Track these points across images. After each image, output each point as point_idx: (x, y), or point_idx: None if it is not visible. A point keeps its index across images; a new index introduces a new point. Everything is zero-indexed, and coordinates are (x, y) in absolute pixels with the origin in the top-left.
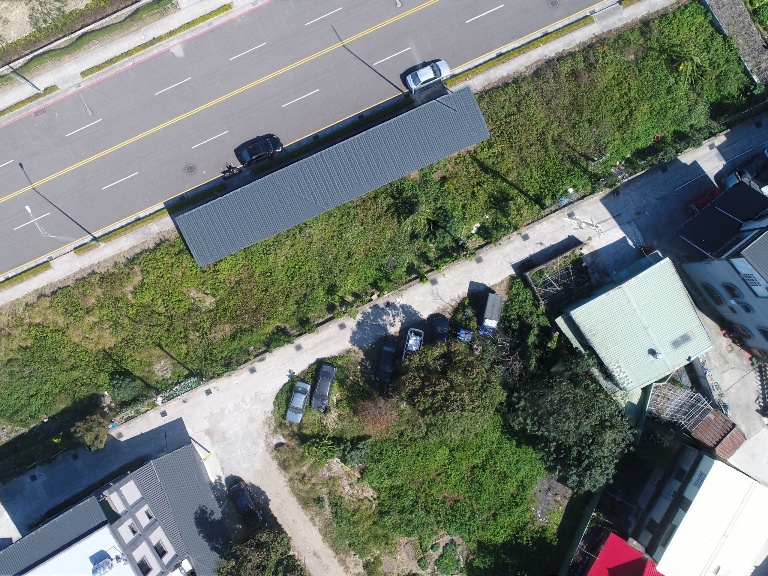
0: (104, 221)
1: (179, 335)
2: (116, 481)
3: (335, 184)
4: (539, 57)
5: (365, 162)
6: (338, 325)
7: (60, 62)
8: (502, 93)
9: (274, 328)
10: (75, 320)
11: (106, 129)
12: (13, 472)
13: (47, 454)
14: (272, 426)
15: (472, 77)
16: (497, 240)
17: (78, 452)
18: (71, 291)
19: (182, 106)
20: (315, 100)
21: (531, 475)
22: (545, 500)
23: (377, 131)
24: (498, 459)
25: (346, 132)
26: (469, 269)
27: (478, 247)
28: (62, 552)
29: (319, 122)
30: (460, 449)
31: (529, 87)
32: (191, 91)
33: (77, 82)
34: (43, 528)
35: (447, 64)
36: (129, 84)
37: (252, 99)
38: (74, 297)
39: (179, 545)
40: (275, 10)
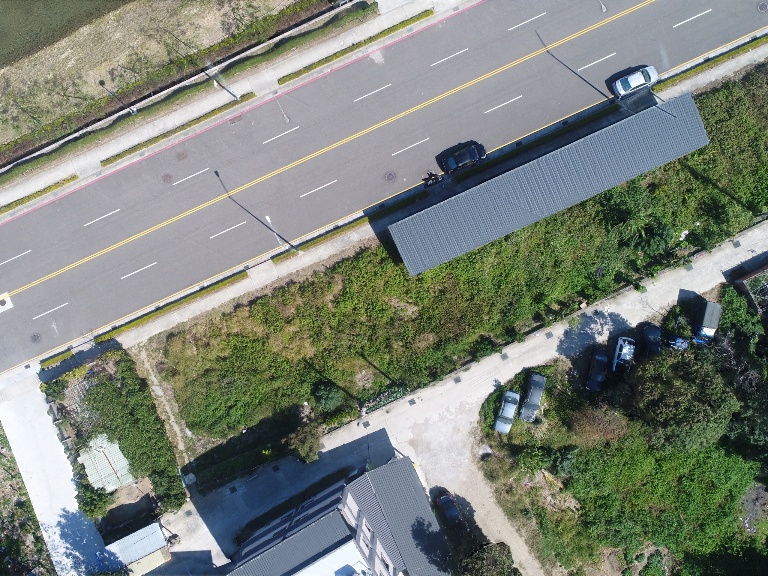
0: (302, 229)
1: (382, 345)
2: (332, 493)
3: (551, 192)
4: (748, 62)
5: (582, 169)
6: (545, 334)
7: (257, 69)
8: (714, 99)
9: (478, 337)
10: (276, 330)
11: (304, 136)
12: (213, 484)
13: (248, 465)
14: (478, 436)
15: (679, 82)
16: (712, 247)
17: (279, 463)
18: (270, 300)
19: (382, 113)
20: (518, 106)
21: (740, 485)
22: (753, 510)
23: (595, 138)
24: (706, 469)
25: (551, 139)
26: (679, 277)
27: (688, 254)
28: (307, 567)
29: (522, 128)
30: (668, 459)
31: (740, 92)
32: (391, 98)
33: (274, 89)
34: (284, 543)
35: (655, 69)
36: (327, 91)
37: (454, 105)
38: (273, 306)
39: (396, 558)
40: (477, 15)
